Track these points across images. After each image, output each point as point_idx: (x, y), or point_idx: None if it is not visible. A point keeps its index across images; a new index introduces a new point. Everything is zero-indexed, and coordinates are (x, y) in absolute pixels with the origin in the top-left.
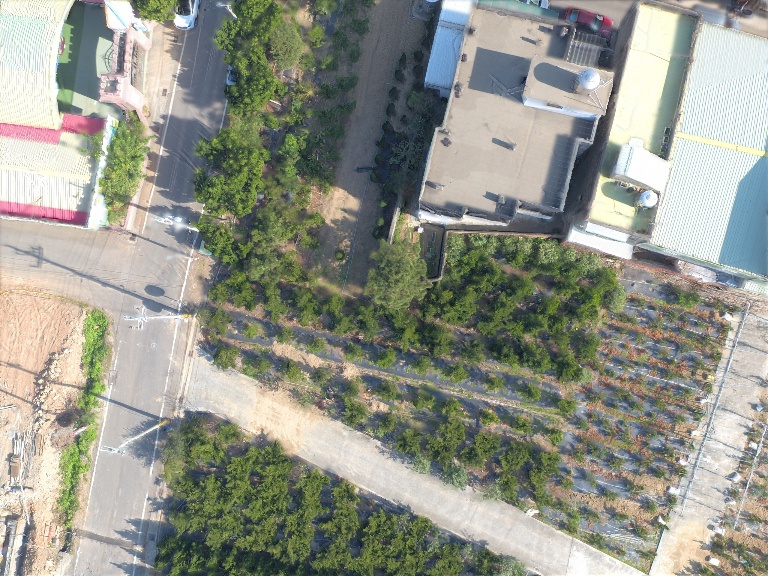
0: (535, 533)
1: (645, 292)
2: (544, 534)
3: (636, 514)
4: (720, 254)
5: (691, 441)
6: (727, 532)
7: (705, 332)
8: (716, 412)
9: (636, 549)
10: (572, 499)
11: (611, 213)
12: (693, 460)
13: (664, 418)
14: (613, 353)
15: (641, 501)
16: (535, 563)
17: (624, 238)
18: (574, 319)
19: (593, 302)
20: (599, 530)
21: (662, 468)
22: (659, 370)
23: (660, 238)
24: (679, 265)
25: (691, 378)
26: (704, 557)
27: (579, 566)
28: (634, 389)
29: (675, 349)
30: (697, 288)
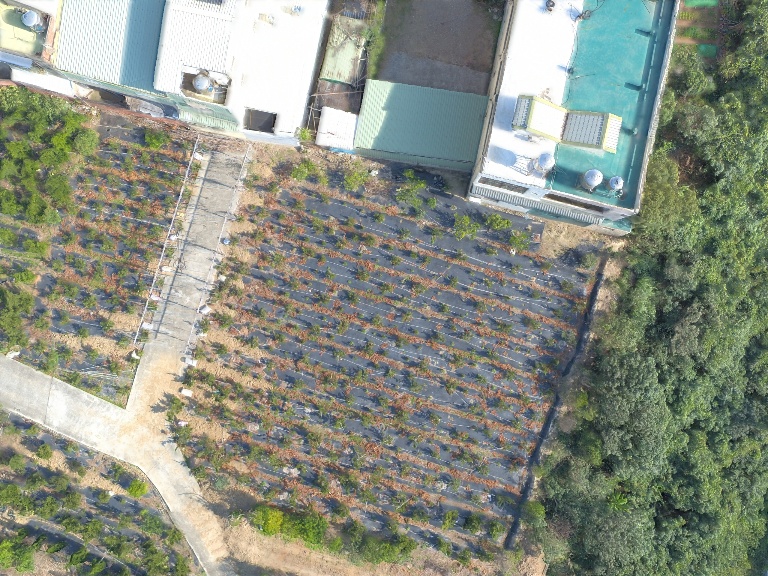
0: (15, 374)
1: (120, 136)
2: (24, 375)
3: (112, 350)
4: (120, 75)
5: (162, 277)
6: (200, 363)
7: (176, 172)
8: (187, 248)
9: (113, 385)
10: (51, 340)
11: (11, 39)
12: (165, 295)
13: (138, 256)
14: (90, 196)
15: (117, 338)
16: (16, 404)
17: (26, 63)
18: (36, 161)
19: (53, 143)
20: (77, 368)
21: (135, 304)
22: (132, 210)
23: (62, 62)
24: (126, 101)
25: (164, 217)
26: (178, 389)
27: (58, 404)
28: (110, 230)
29: (147, 189)
30: (167, 130)
